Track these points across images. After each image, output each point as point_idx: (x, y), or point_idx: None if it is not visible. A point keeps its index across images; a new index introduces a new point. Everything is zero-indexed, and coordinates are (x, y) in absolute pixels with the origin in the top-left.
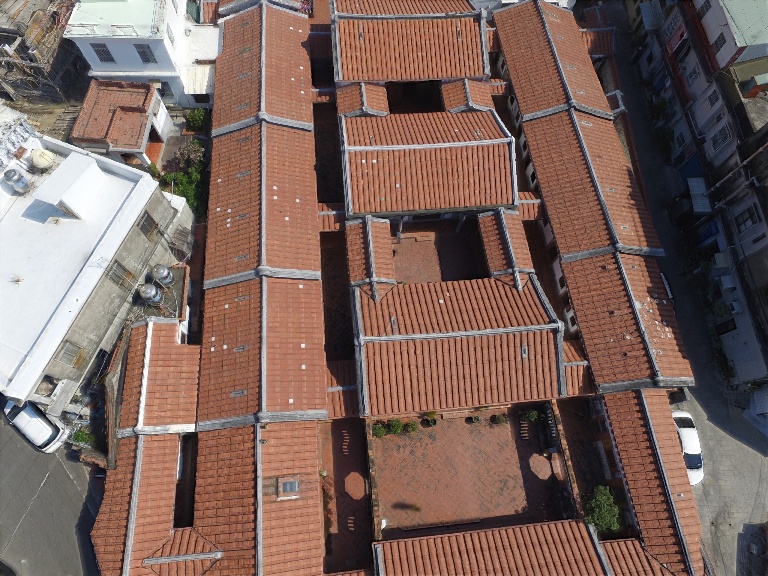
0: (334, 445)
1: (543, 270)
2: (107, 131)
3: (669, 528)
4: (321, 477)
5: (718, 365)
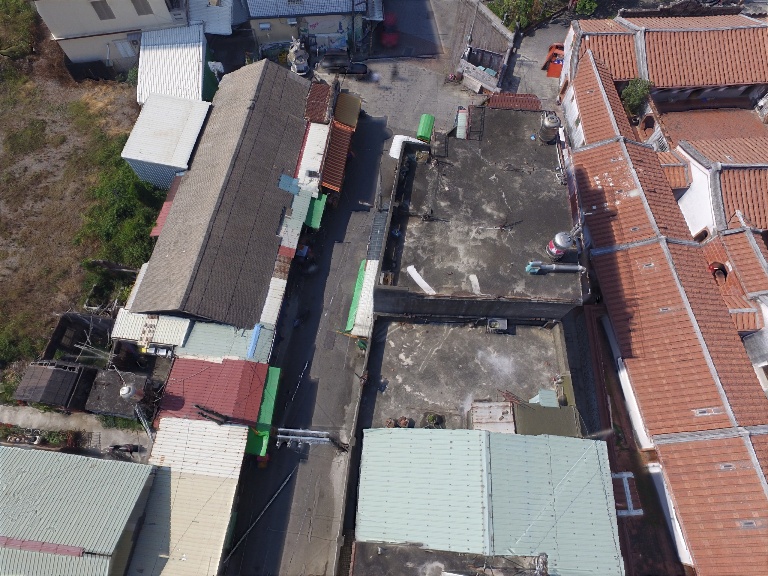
0: None
1: None
2: None
3: (602, 76)
4: None
5: None
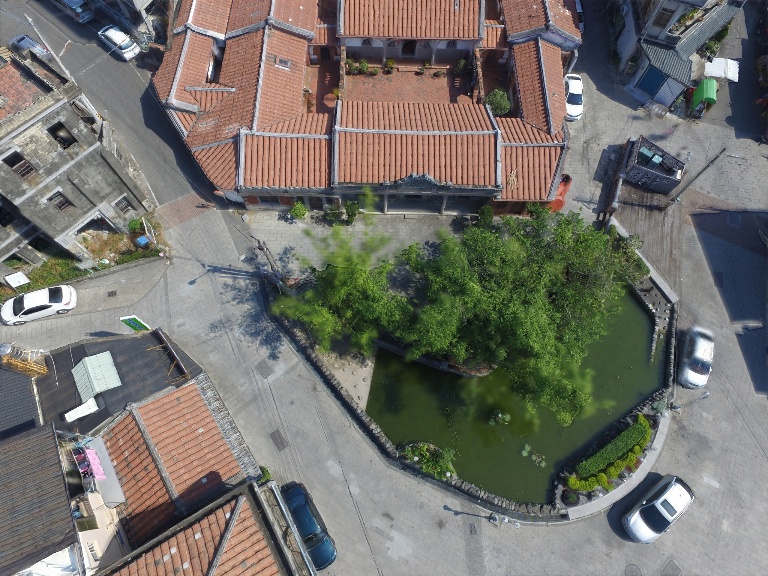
0: (319, 79)
1: None
2: None
3: (541, 107)
4: (307, 93)
5: (612, 60)
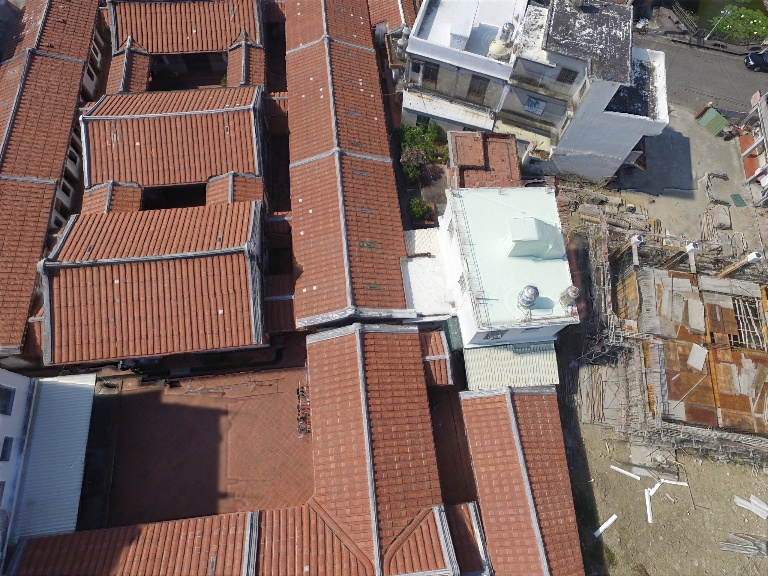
0: None
1: None
2: (487, 149)
3: None
4: None
5: None
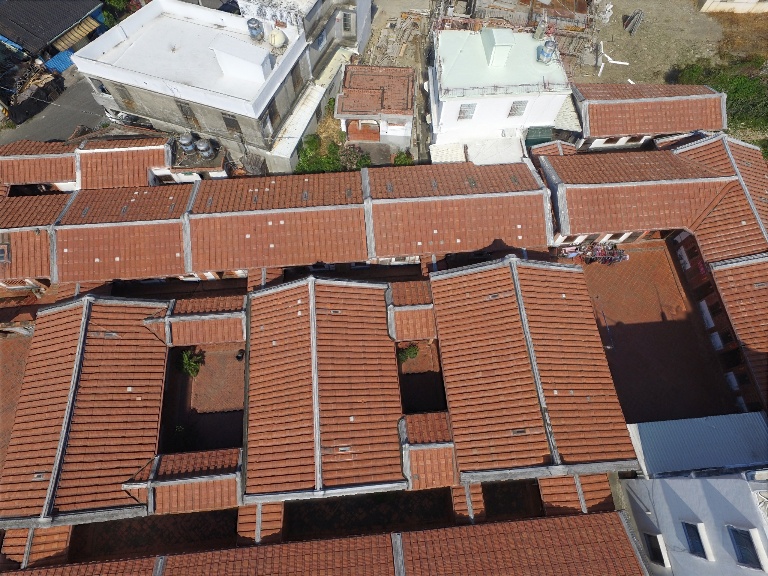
0: None
1: (197, 550)
2: None
3: None
4: None
5: None
